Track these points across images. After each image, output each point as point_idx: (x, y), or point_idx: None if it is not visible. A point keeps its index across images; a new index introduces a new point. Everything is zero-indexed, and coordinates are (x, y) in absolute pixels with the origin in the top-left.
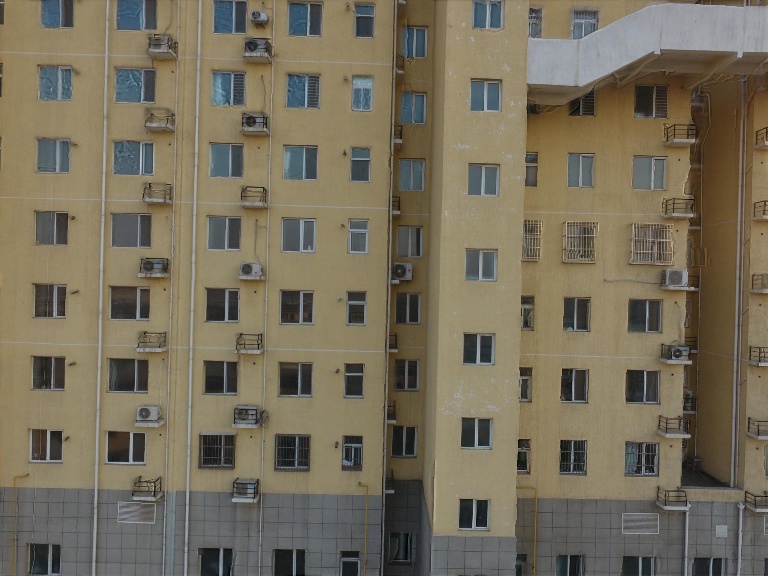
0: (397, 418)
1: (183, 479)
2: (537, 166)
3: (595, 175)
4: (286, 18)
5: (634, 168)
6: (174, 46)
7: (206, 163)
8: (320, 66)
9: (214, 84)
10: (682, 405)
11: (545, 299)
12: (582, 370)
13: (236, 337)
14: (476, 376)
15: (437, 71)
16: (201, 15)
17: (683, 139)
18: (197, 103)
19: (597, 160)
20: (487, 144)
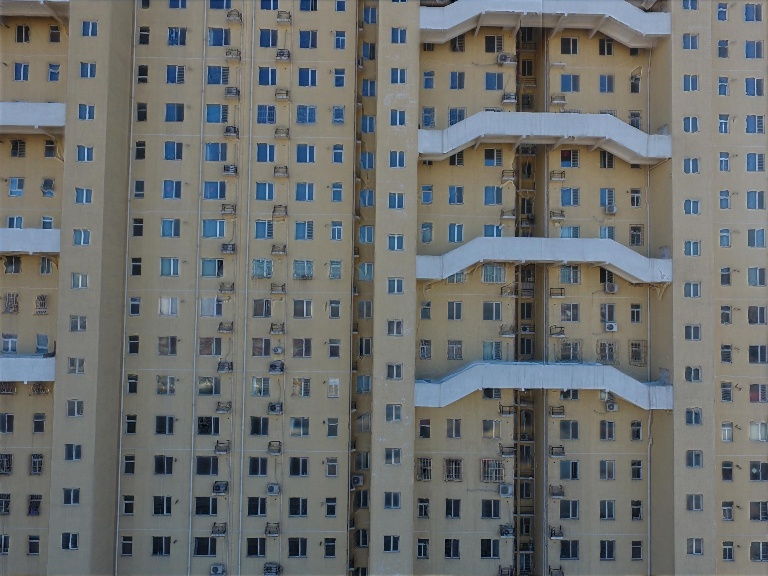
0: (355, 566)
1: None
2: (430, 427)
3: (462, 431)
4: (292, 347)
5: (483, 426)
6: (231, 364)
7: (248, 428)
8: (310, 374)
9: (252, 383)
10: (512, 559)
11: (435, 501)
12: (457, 539)
13: (265, 525)
14: (390, 558)
15: None
16: (246, 348)
17: (507, 414)
18: (243, 396)
19: (463, 423)
20: (394, 438)
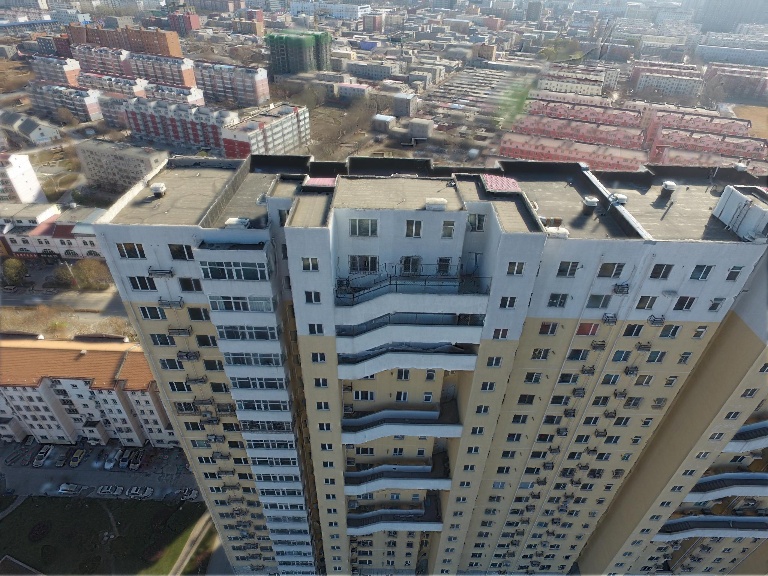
0: None
1: (512, 570)
2: None
3: None
4: None
5: None
6: None
7: None
8: None
9: None
10: None
11: None
12: None
13: None
14: None
15: (621, 511)
16: None
17: None
18: None
19: None
20: None
